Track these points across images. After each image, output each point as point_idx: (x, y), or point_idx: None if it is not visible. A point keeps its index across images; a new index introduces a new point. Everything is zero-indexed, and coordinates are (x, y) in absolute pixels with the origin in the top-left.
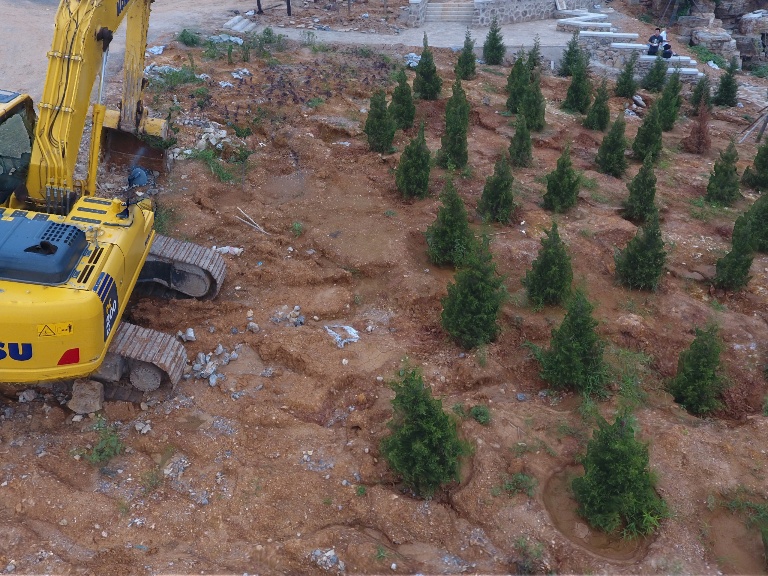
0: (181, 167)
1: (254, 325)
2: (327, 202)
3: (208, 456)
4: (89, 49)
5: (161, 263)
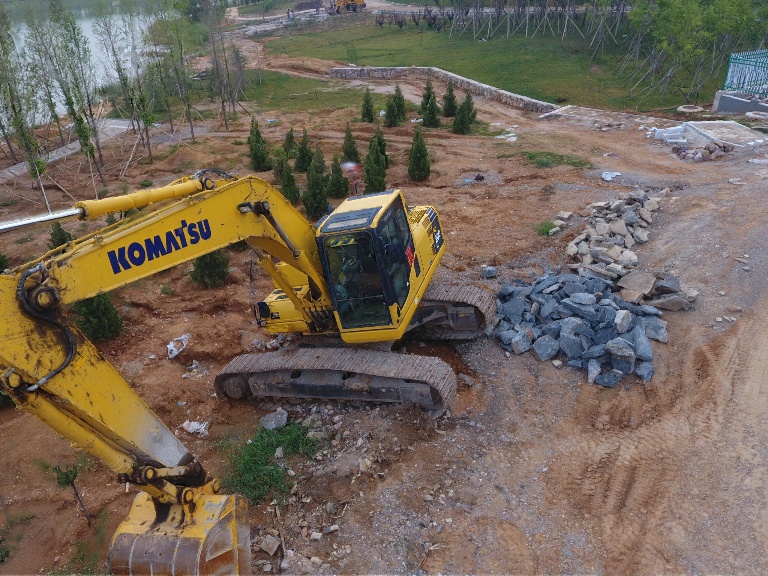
0: None
1: None
2: (8, 498)
3: None
4: None
5: None
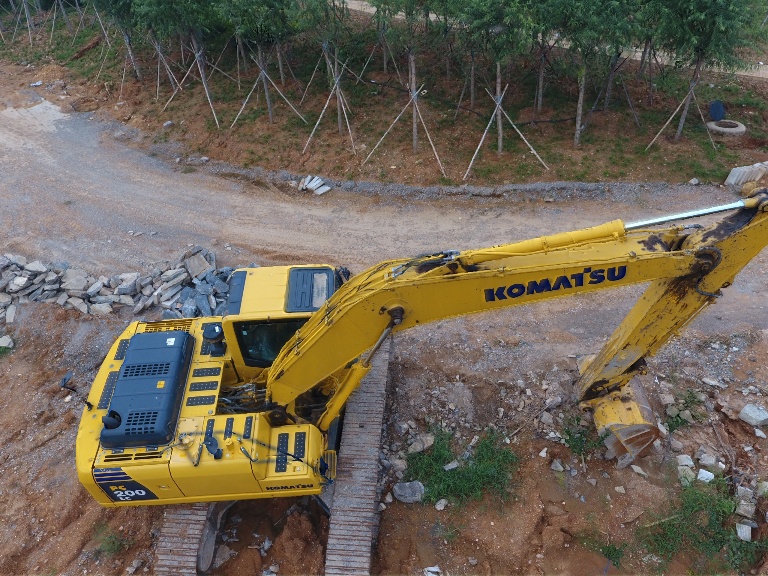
0: (639, 478)
1: None
2: None
3: None
4: (362, 318)
5: None
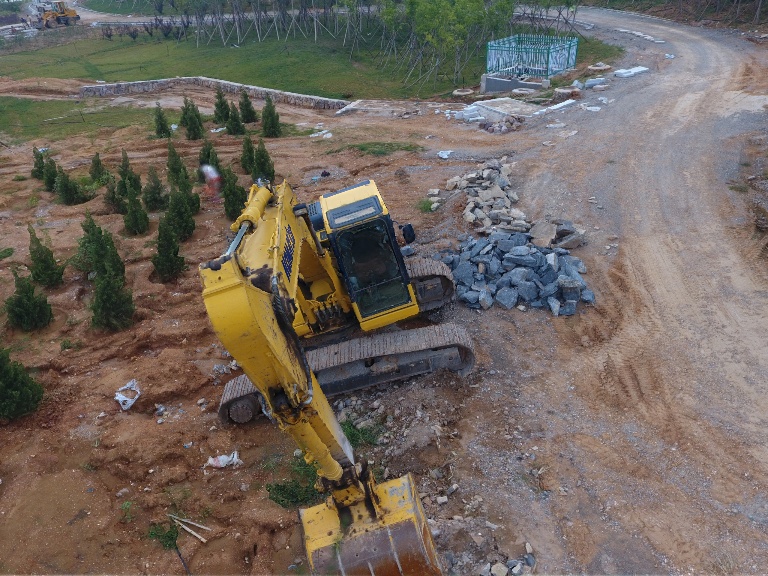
0: None
1: None
2: None
3: None
4: None
5: None
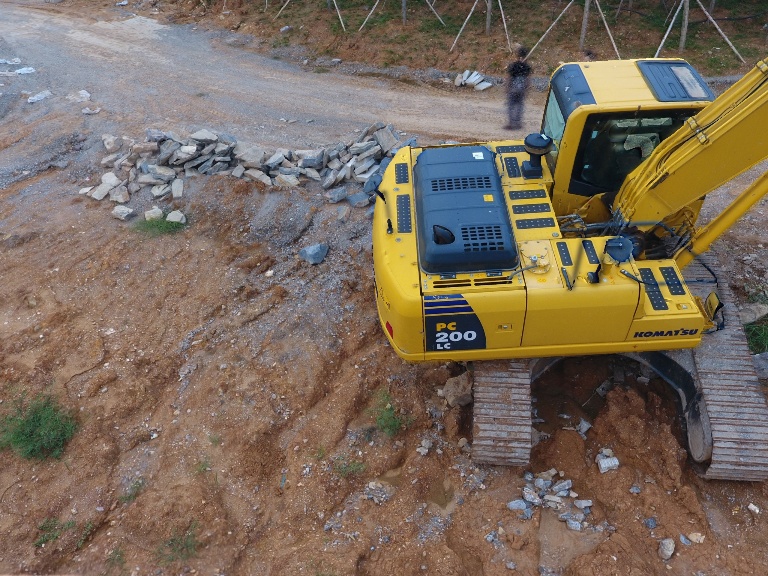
0: None
1: (668, 547)
2: None
3: (383, 517)
4: None
5: (693, 381)
